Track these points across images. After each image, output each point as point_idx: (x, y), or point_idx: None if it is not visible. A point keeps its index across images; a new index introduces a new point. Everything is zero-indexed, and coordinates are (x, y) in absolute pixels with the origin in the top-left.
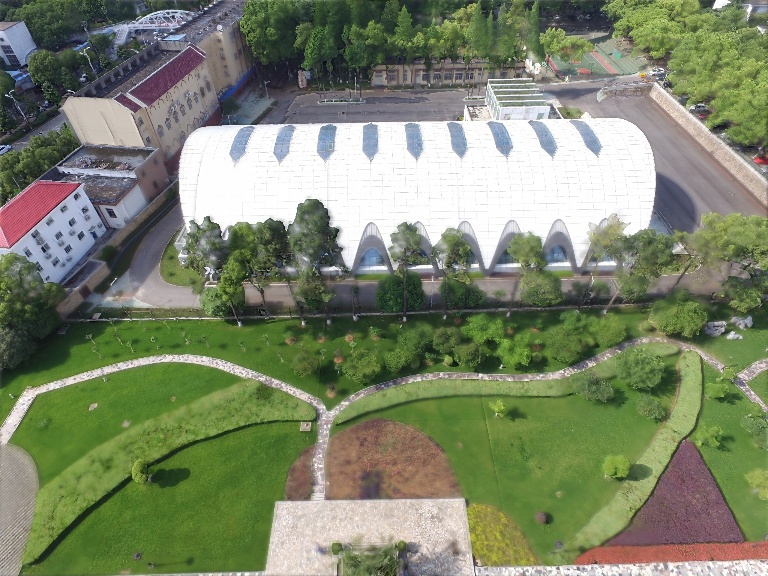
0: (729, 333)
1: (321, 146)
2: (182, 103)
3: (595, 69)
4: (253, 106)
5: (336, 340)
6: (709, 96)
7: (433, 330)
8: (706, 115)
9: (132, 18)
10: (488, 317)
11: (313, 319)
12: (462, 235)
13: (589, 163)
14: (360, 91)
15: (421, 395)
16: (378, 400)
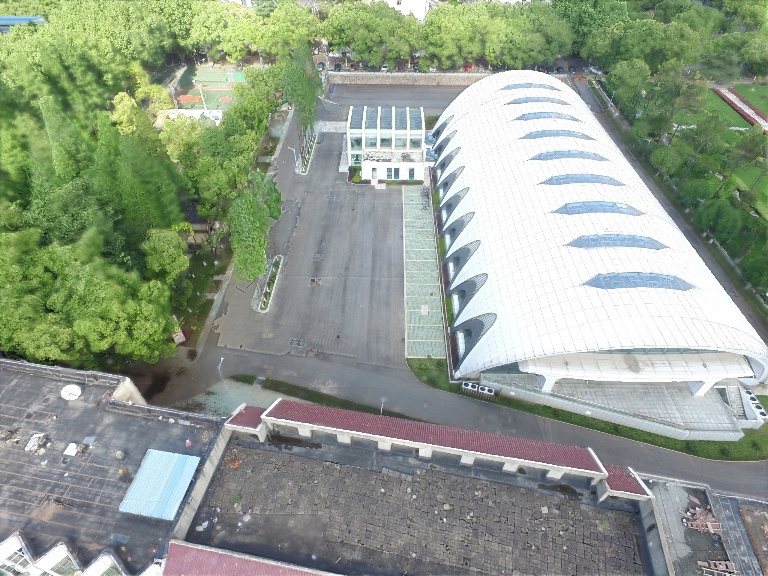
0: None
1: None
2: None
3: None
4: None
5: None
6: None
7: None
8: (402, 67)
9: None
10: None
11: None
12: None
13: None
14: None
15: None
16: None
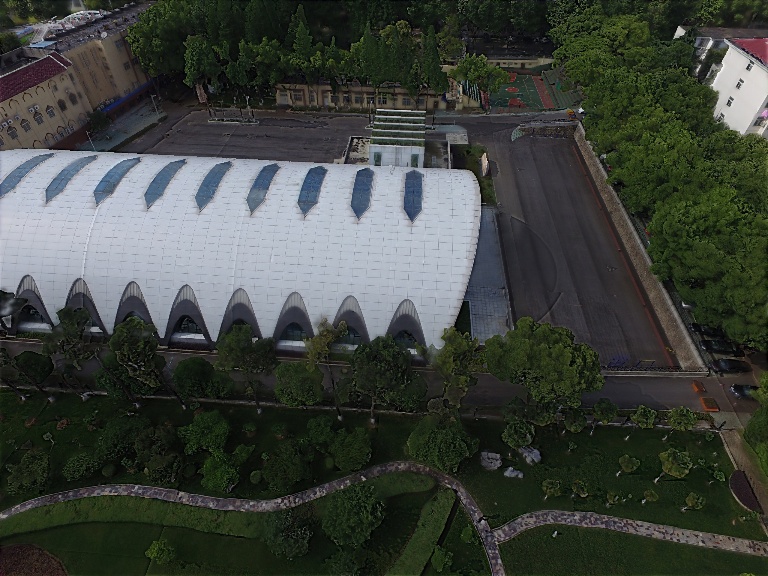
0: (507, 468)
1: (104, 185)
2: (25, 118)
3: (529, 100)
4: (139, 120)
5: (46, 425)
6: (612, 147)
7: (146, 428)
8: None
9: (63, 17)
10: (216, 417)
11: (39, 393)
12: (236, 305)
13: (400, 229)
14: (252, 111)
15: (91, 517)
16: (37, 518)
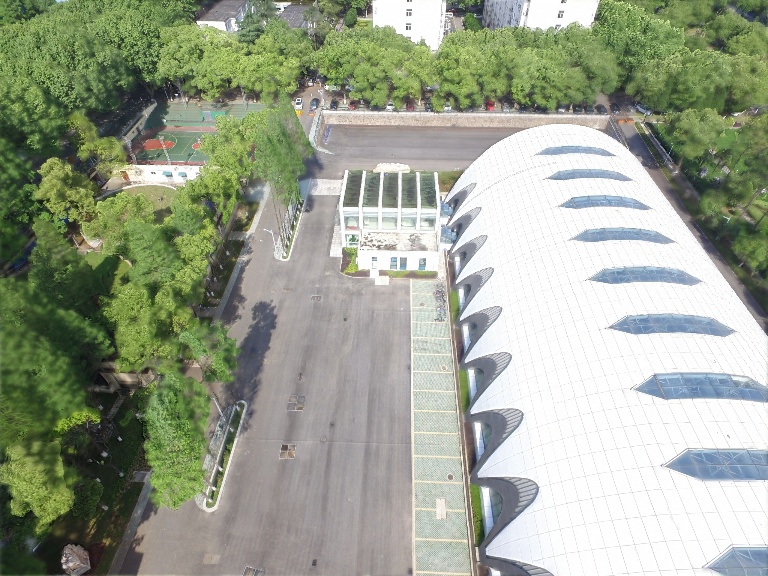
0: None
1: None
2: None
3: None
4: None
5: None
6: None
7: None
8: (411, 106)
9: None
10: None
11: None
12: None
13: (627, 164)
14: None
15: None
16: None
